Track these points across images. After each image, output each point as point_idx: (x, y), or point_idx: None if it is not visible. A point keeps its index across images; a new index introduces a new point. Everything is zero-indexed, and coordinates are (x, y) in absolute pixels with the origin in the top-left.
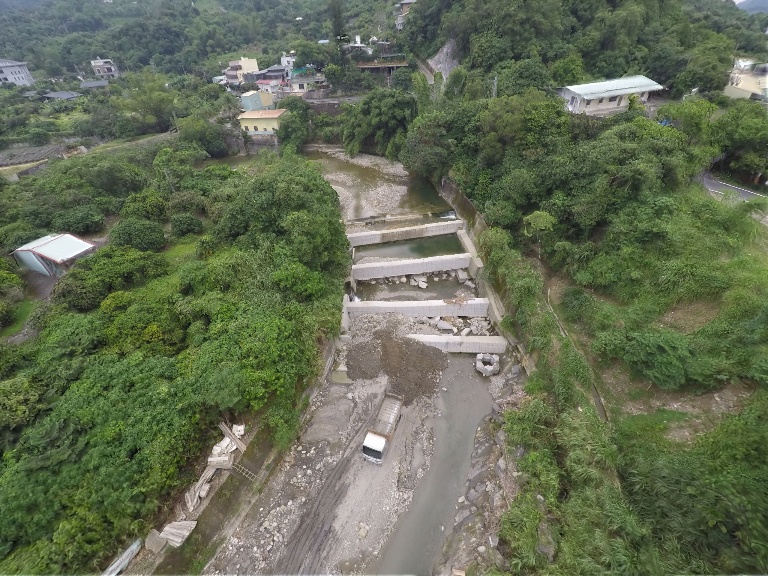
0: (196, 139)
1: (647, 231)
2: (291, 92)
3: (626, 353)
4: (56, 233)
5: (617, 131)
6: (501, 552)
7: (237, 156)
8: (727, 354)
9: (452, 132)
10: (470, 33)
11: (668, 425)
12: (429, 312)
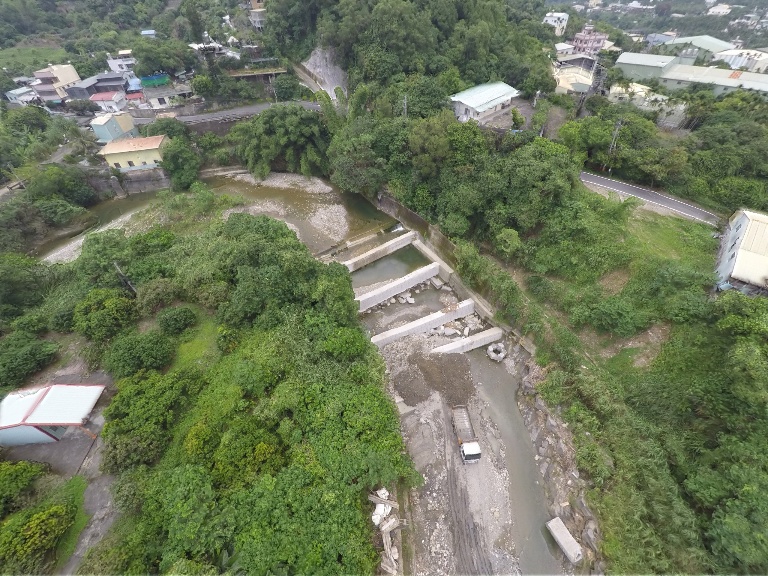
0: (55, 192)
1: (574, 229)
2: (151, 110)
3: (594, 320)
4: (5, 386)
5: (530, 152)
6: (581, 478)
7: (114, 200)
8: (647, 305)
9: (377, 150)
10: (352, 43)
11: (632, 358)
12: (434, 324)
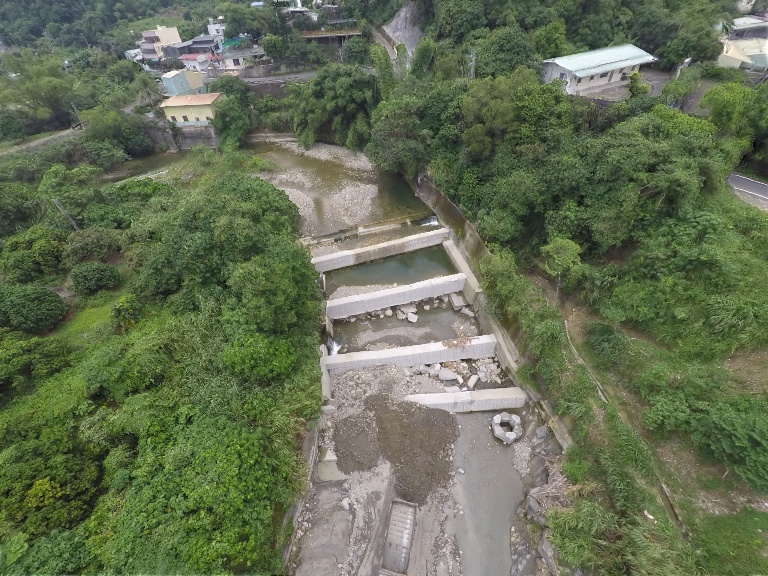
0: (109, 137)
1: (693, 259)
2: (224, 69)
3: (693, 431)
4: None
5: (639, 126)
6: None
7: (166, 153)
8: None
9: (426, 120)
10: None
11: (766, 537)
12: (427, 359)
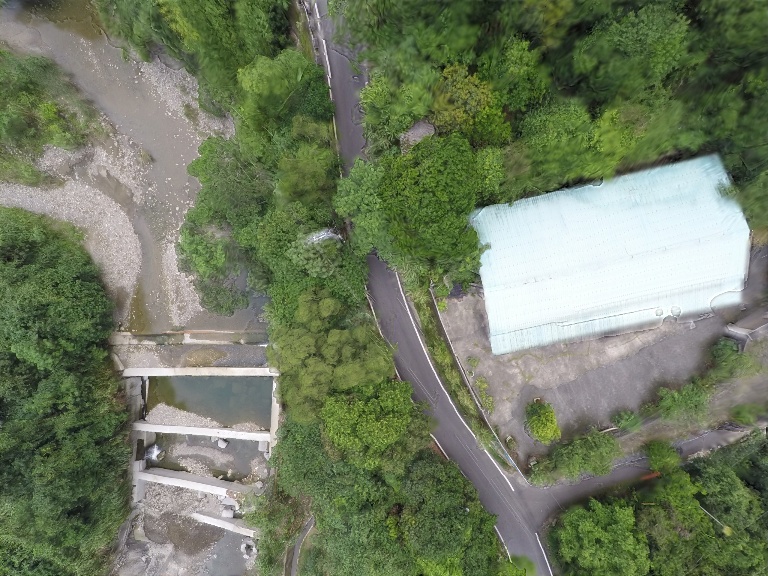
0: None
1: None
2: None
3: None
4: None
5: None
6: None
7: None
8: None
9: None
10: None
11: None
12: None
